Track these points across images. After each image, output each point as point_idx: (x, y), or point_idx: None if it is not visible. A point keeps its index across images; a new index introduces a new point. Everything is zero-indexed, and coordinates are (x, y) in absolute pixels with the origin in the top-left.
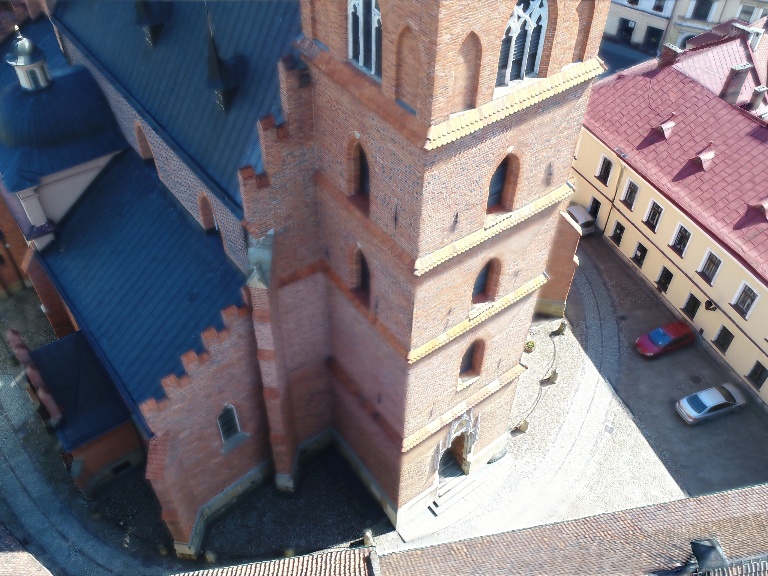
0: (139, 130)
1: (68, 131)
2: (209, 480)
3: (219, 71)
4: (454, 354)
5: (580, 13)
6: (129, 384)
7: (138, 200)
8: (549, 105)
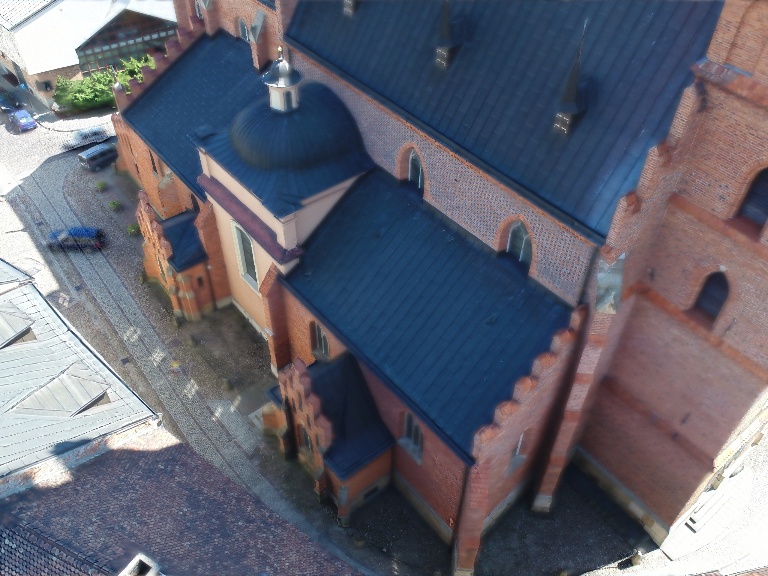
0: (405, 151)
1: (321, 153)
2: None
3: (575, 95)
4: None
5: None
6: (429, 411)
7: (397, 221)
8: None
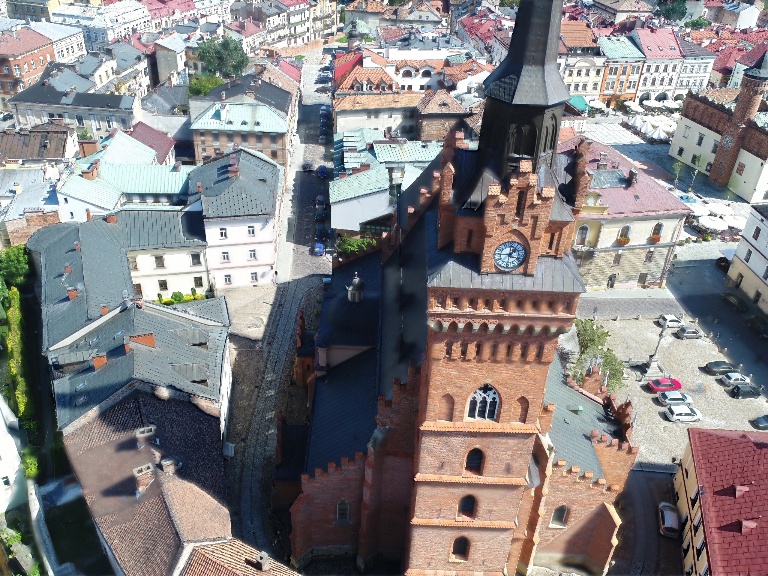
0: None
1: (356, 327)
2: (322, 534)
3: (401, 346)
4: (446, 536)
5: (521, 403)
6: (309, 463)
7: (367, 376)
8: (503, 435)
